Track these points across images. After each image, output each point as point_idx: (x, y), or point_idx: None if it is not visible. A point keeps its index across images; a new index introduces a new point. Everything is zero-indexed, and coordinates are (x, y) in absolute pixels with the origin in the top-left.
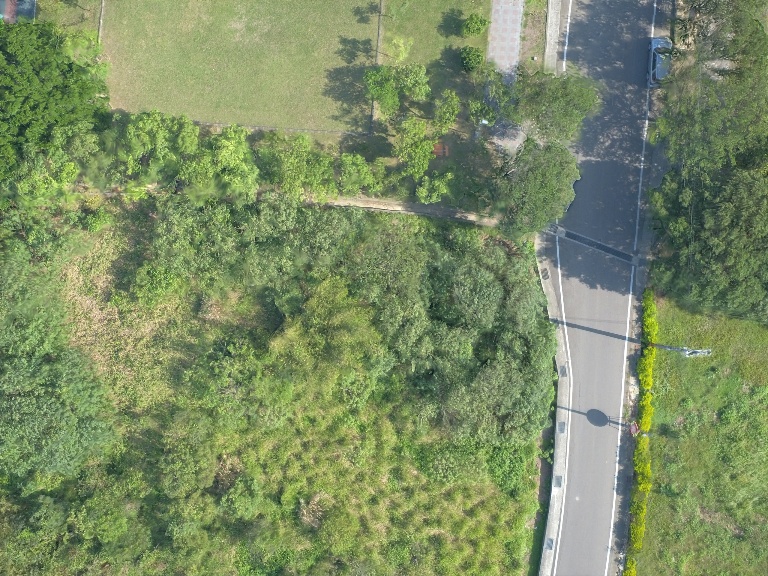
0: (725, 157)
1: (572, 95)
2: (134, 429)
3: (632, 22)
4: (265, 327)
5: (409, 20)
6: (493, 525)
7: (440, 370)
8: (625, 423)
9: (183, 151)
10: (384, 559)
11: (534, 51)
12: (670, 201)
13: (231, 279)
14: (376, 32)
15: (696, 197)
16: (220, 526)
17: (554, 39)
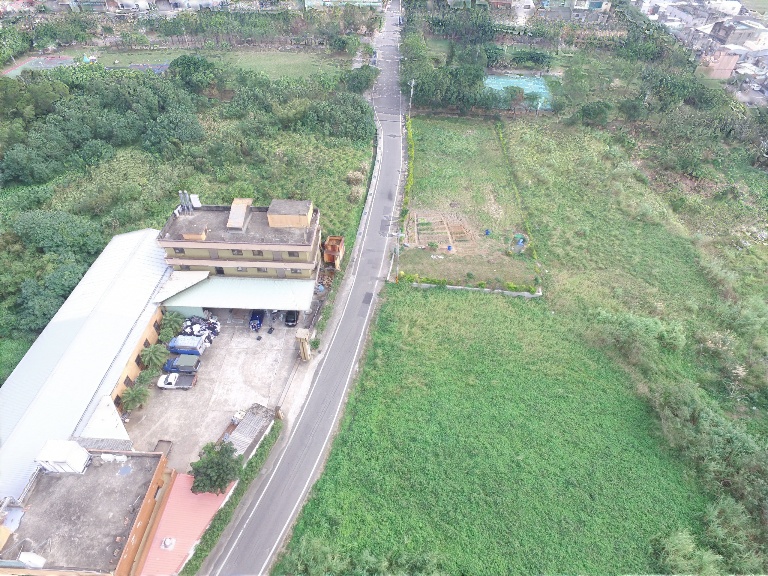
0: None
1: (372, 68)
2: None
3: None
4: None
5: None
6: None
7: None
8: None
9: None
10: None
11: None
12: None
13: None
14: None
15: None
16: None
17: None
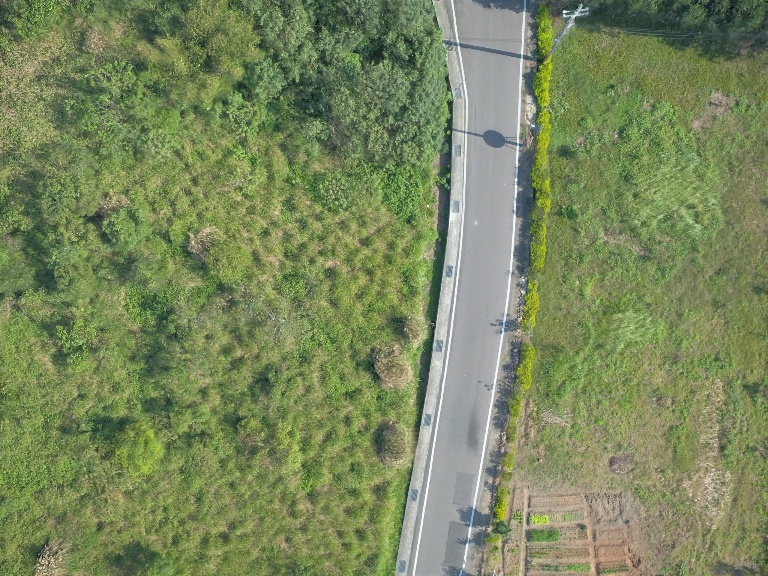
0: None
1: None
2: (19, 171)
3: None
4: None
5: None
6: (390, 253)
7: (327, 84)
8: (523, 143)
9: None
10: (279, 295)
11: None
12: None
13: (116, 14)
14: None
15: None
16: (108, 266)
17: None
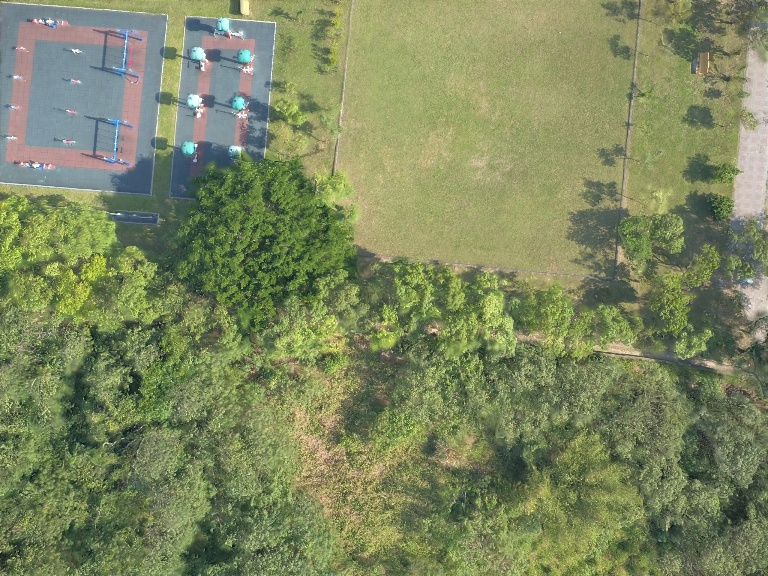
0: None
1: None
2: (361, 574)
3: None
4: (501, 473)
5: (654, 164)
6: None
7: (690, 527)
8: None
9: (452, 308)
10: None
11: None
12: None
13: None
14: (621, 175)
15: None
16: None
17: None
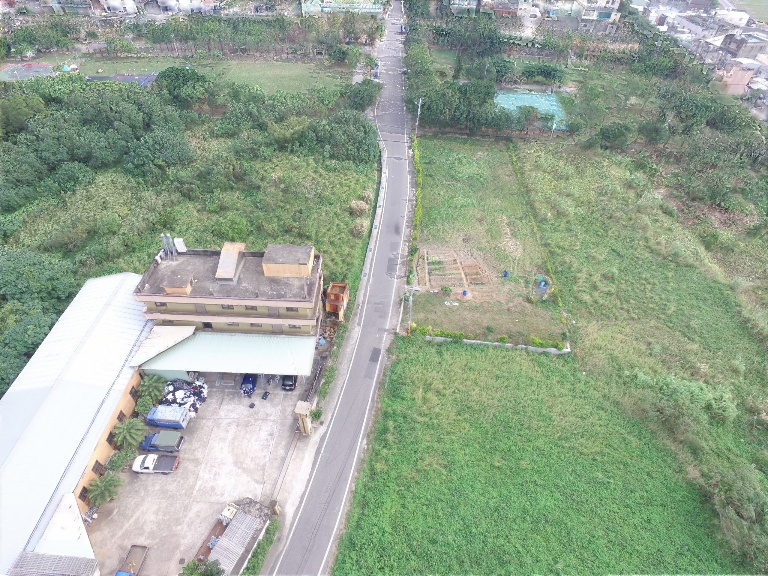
0: None
1: (375, 83)
2: None
3: None
4: None
5: None
6: None
7: (333, 138)
8: None
9: None
10: None
11: None
12: None
13: None
14: None
15: None
16: None
17: None
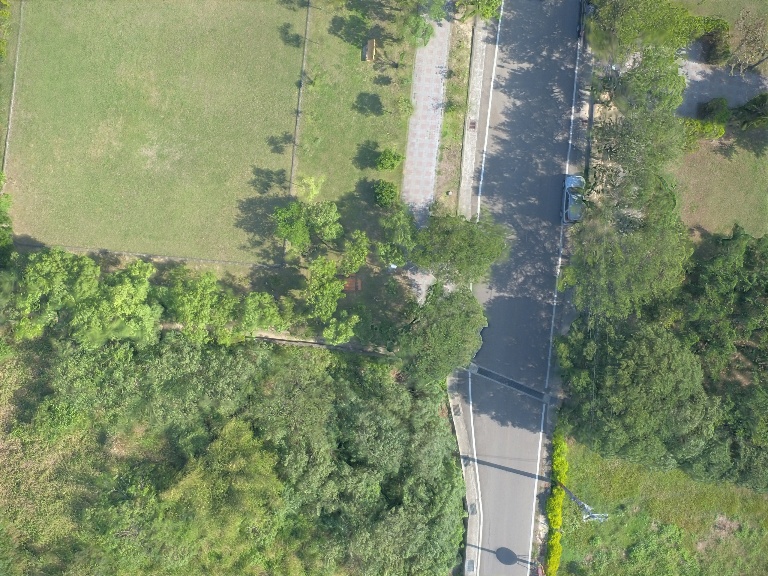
0: (631, 307)
1: (479, 244)
2: (35, 564)
3: (547, 158)
4: (172, 461)
5: (324, 151)
6: None
7: (347, 512)
8: (534, 562)
9: (81, 296)
10: None
11: (449, 186)
12: (576, 352)
13: (138, 411)
14: (290, 162)
15: (601, 350)
16: None
17: (469, 174)
